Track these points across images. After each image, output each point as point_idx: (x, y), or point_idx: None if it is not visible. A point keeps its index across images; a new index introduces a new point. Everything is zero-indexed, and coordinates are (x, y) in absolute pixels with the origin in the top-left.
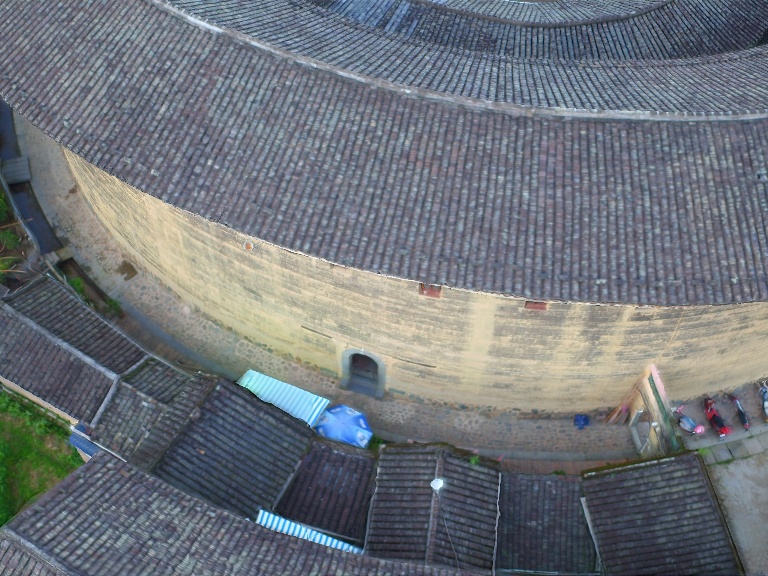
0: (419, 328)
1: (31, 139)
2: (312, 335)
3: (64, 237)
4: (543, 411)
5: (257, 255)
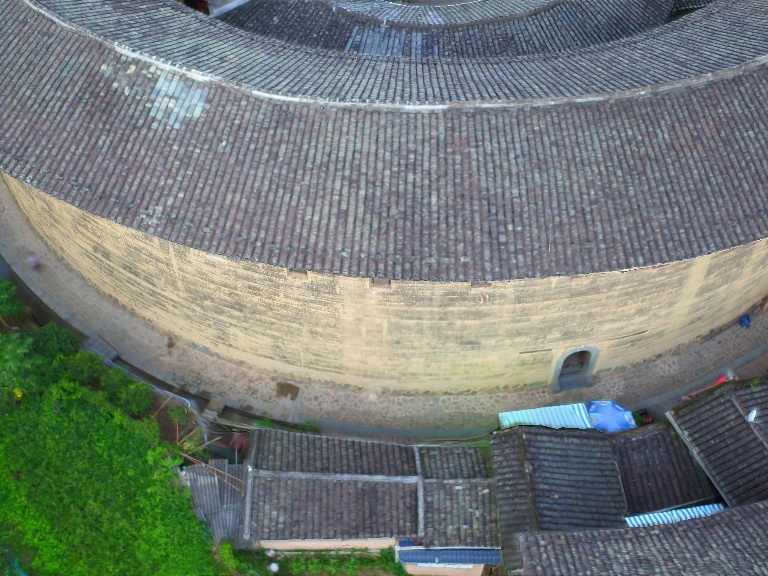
0: (644, 301)
1: (84, 316)
2: (530, 357)
3: (200, 391)
4: (718, 327)
5: (487, 304)
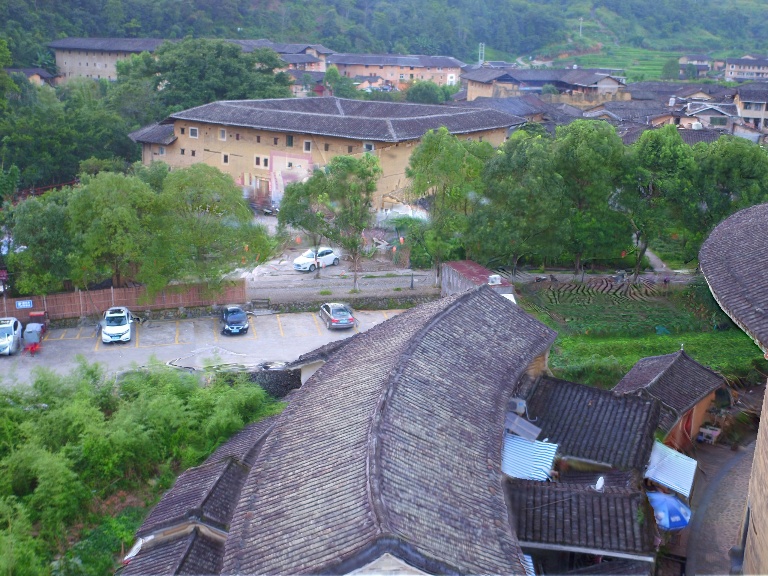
0: None
1: None
2: None
3: None
4: None
5: None
